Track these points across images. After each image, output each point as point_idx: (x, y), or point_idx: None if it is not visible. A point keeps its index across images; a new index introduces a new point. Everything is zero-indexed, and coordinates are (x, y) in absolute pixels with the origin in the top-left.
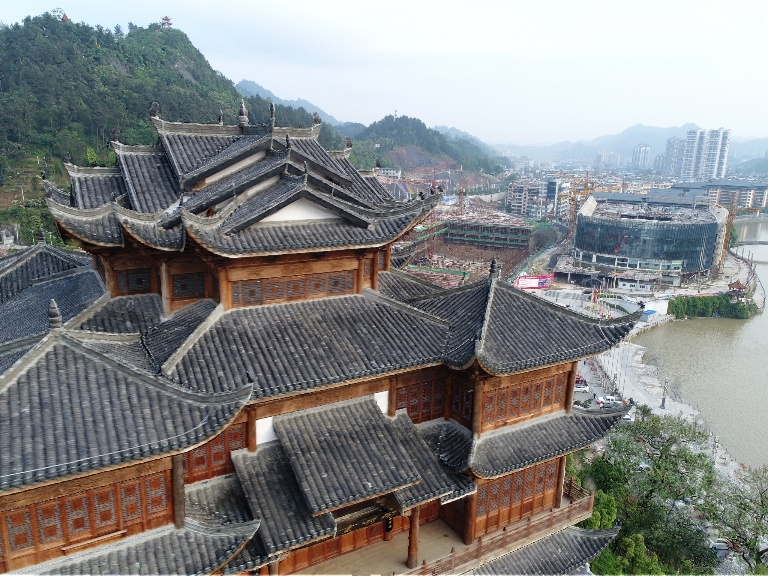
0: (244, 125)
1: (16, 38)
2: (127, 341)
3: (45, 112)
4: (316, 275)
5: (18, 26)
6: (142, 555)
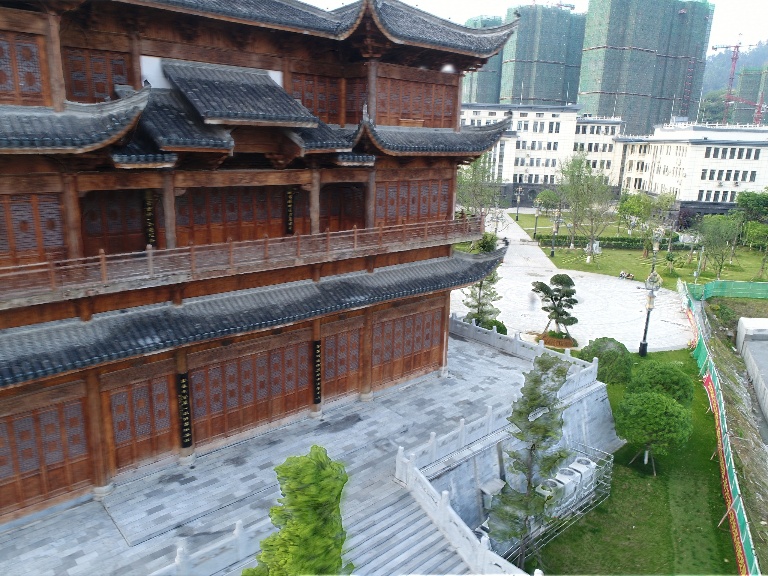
0: None
1: None
2: None
3: None
4: None
5: None
6: None
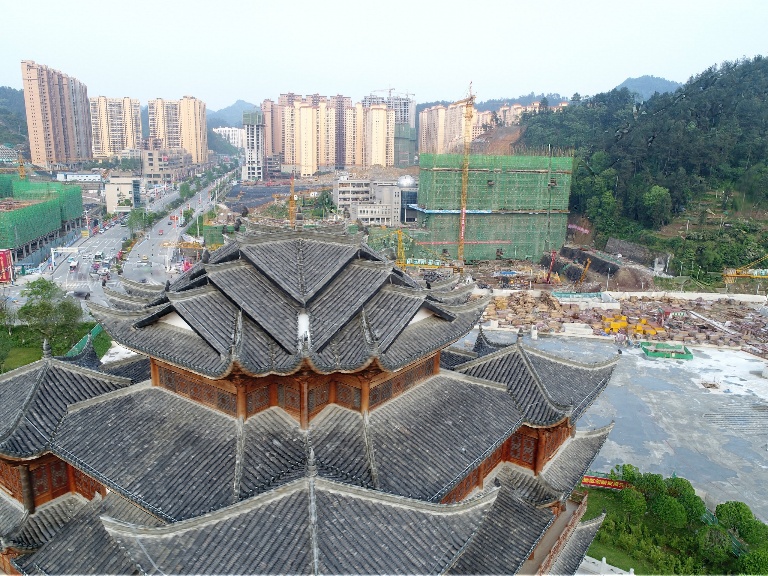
0: (295, 228)
1: (752, 71)
2: (116, 381)
3: (745, 145)
4: (209, 385)
5: (759, 58)
6: (7, 514)
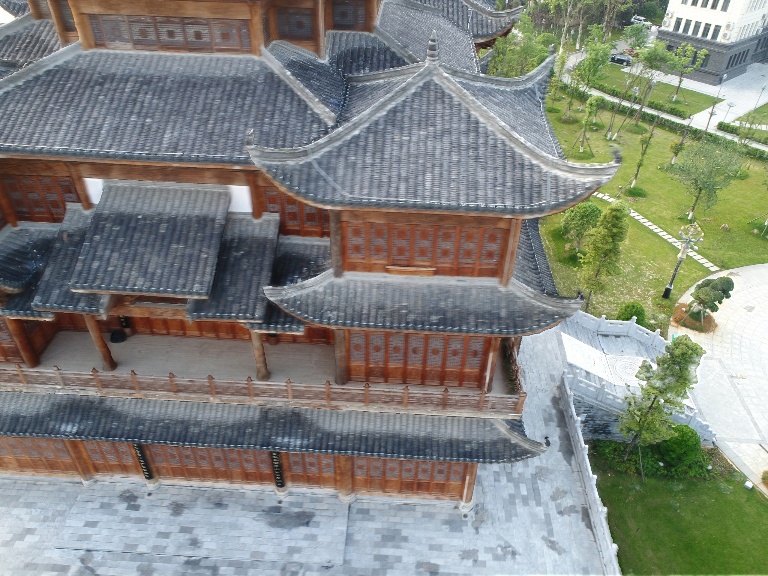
0: None
1: None
2: None
3: None
4: None
5: None
6: None
